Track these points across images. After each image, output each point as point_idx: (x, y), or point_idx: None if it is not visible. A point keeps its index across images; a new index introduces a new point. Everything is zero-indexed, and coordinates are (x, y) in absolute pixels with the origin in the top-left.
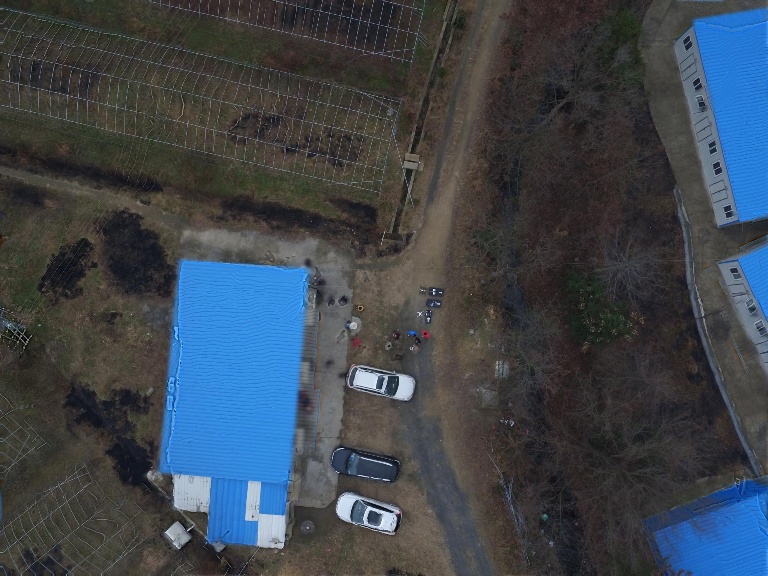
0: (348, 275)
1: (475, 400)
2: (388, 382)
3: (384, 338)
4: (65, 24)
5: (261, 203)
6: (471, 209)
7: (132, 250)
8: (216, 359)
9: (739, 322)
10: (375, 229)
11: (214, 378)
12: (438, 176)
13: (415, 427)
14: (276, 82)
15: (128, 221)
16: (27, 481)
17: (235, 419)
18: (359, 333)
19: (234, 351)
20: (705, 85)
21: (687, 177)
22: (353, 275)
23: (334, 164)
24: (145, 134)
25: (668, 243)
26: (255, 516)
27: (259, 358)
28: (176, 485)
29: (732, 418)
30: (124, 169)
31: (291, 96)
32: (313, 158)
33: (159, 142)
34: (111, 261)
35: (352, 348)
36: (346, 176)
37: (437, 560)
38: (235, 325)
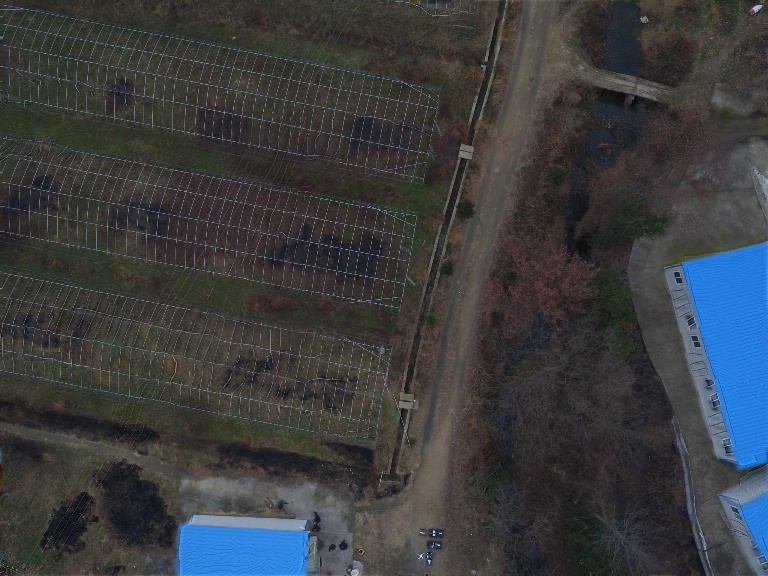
0: (347, 519)
1: None
2: None
3: None
4: (55, 282)
5: (258, 448)
6: (468, 448)
7: (132, 502)
8: None
9: (742, 554)
10: (373, 470)
11: None
12: (434, 414)
13: None
14: (267, 338)
15: (127, 473)
16: None
17: None
18: None
19: None
20: (700, 327)
21: (685, 407)
22: (352, 518)
23: (329, 414)
24: (139, 393)
25: (668, 473)
26: None
27: None
28: None
29: None
30: (120, 421)
31: (283, 352)
32: (307, 415)
33: (154, 400)
34: (112, 514)
35: None
36: (341, 425)
37: None
38: None
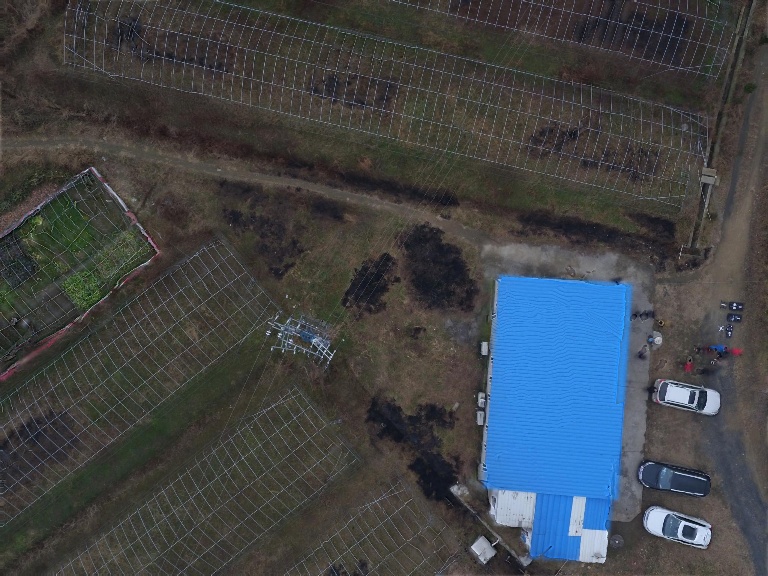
0: (648, 290)
1: None
2: (699, 397)
3: (684, 352)
4: (370, 37)
5: (559, 217)
6: None
7: (434, 265)
8: (525, 374)
9: None
10: (673, 244)
11: (520, 393)
12: (734, 191)
13: (717, 441)
14: (588, 97)
15: (429, 235)
16: (336, 496)
17: (541, 434)
18: (660, 347)
19: (543, 366)
20: None
21: None
22: (653, 290)
23: (641, 179)
24: (455, 149)
25: None
26: (578, 531)
27: (564, 373)
28: (499, 501)
29: None
30: (425, 183)
31: (604, 111)
32: (628, 174)
33: (469, 157)
34: (414, 276)
35: (654, 362)
36: (652, 191)
37: (742, 573)
38: (544, 340)
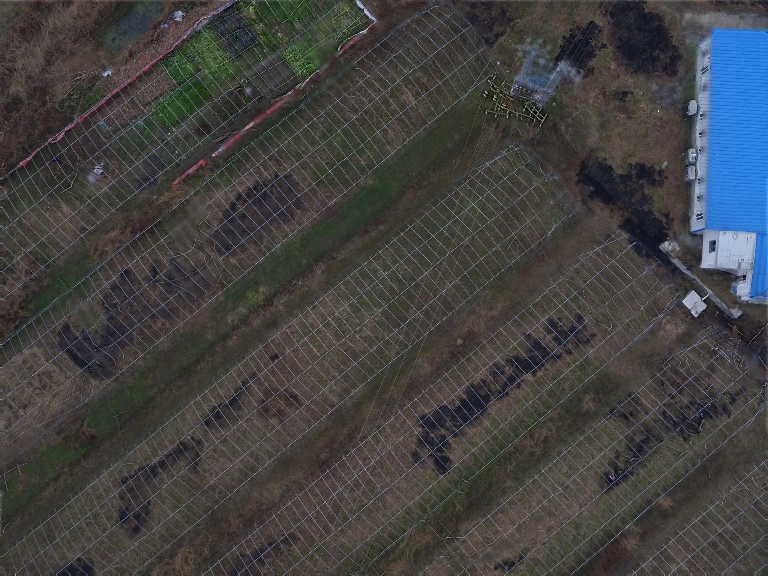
0: None
1: None
2: None
3: None
4: None
5: None
6: None
7: (638, 32)
8: (732, 131)
9: None
10: None
11: (727, 151)
12: None
13: None
14: None
15: (632, 5)
16: (554, 251)
17: (747, 190)
18: None
19: (749, 123)
20: None
21: None
22: None
23: None
24: None
25: None
26: None
27: (767, 132)
28: (720, 242)
29: None
30: None
31: None
32: None
33: None
34: (619, 42)
35: None
36: None
37: None
38: (750, 98)
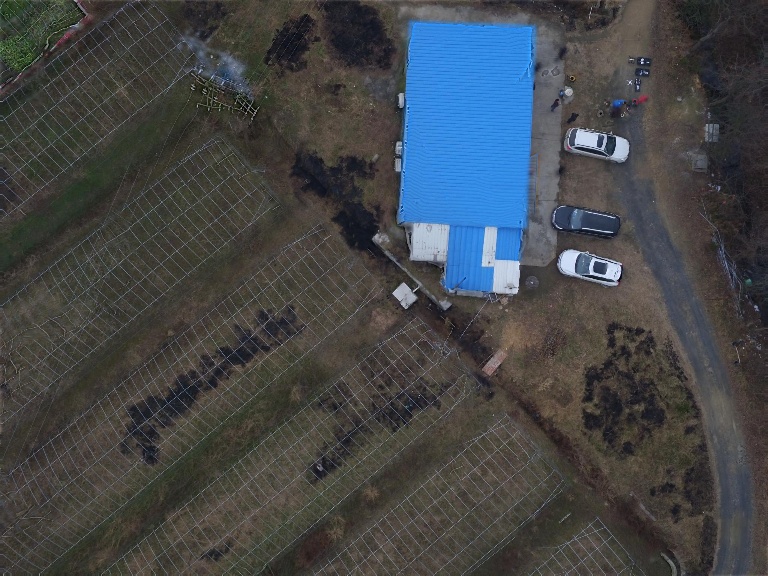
0: (559, 47)
1: (685, 162)
2: (607, 141)
3: (595, 106)
4: None
5: None
6: None
7: (353, 25)
8: (440, 124)
9: None
10: (583, 4)
11: (437, 143)
12: None
13: (628, 189)
14: None
15: None
16: (261, 243)
17: (458, 183)
18: (572, 102)
19: (458, 115)
20: None
21: None
22: (564, 47)
23: None
24: None
25: None
26: (491, 262)
27: (479, 125)
28: (415, 234)
29: None
30: None
31: None
32: None
33: None
34: (333, 35)
35: (566, 116)
36: None
37: (654, 314)
38: (458, 91)
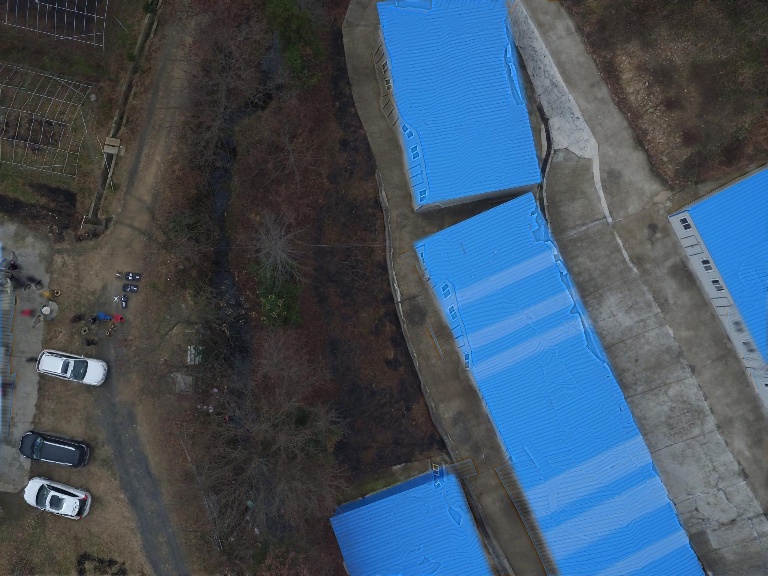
0: (45, 260)
1: (169, 385)
2: (74, 366)
3: (81, 323)
4: None
5: None
6: (169, 193)
7: None
8: None
9: (435, 307)
10: (74, 213)
11: None
12: (139, 160)
13: (109, 412)
14: None
15: None
16: None
17: None
18: (55, 318)
19: None
20: (391, 68)
21: (388, 161)
22: (51, 260)
23: (25, 148)
24: None
25: (370, 228)
26: None
27: None
28: None
29: (427, 403)
30: None
31: None
32: None
33: None
34: None
35: (48, 333)
36: (38, 160)
37: (128, 545)
38: None
